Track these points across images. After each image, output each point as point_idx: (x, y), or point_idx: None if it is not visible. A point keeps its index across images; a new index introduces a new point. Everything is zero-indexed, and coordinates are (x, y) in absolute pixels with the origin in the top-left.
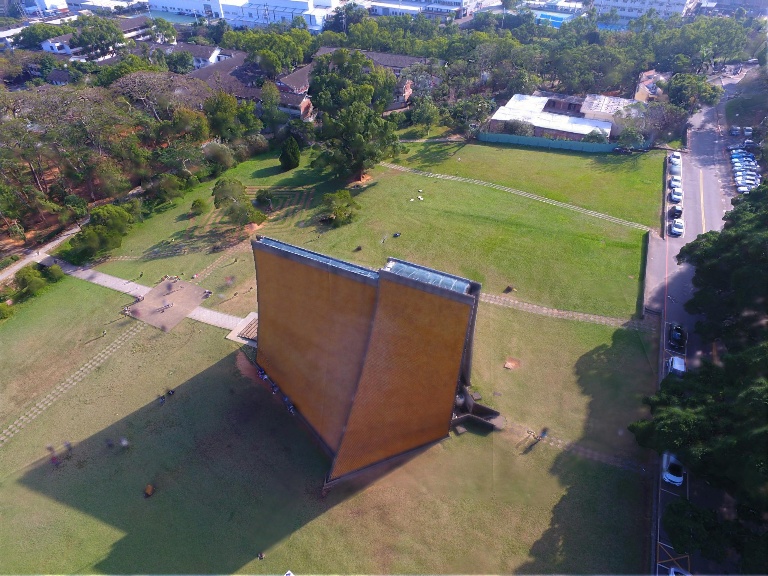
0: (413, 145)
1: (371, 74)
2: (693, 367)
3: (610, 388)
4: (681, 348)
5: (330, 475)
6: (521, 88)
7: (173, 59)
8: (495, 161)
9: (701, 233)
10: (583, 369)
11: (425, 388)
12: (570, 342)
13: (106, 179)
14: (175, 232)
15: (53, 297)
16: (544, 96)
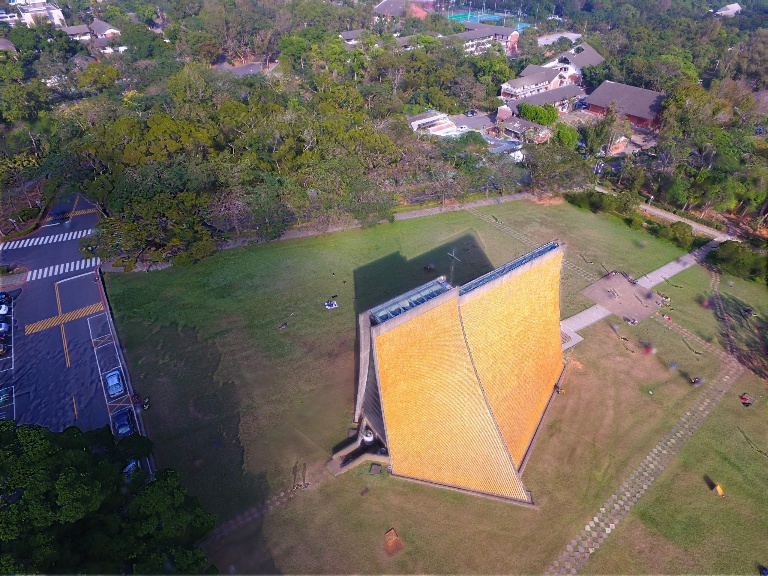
0: None
1: None
2: None
3: None
4: None
5: None
6: None
7: None
8: None
9: None
10: None
11: None
12: None
13: None
14: None
15: (652, 244)
16: None
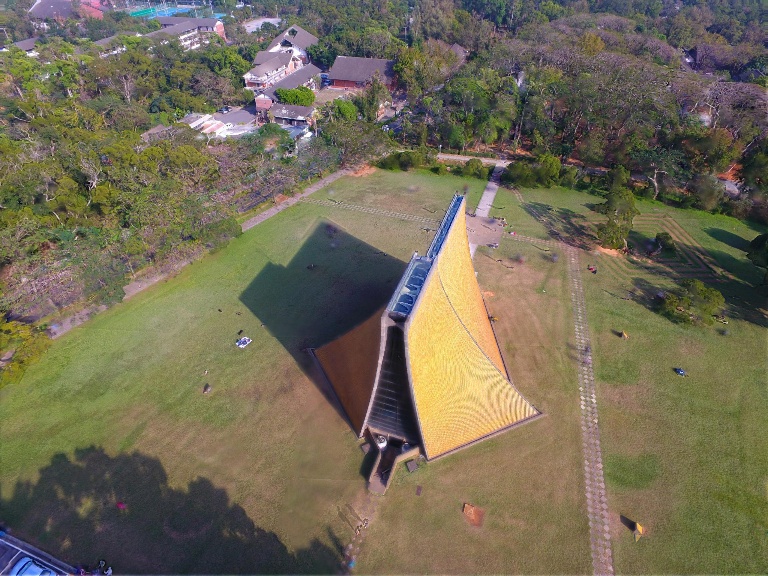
0: None
1: None
2: None
3: None
4: None
5: (316, 349)
6: None
7: None
8: None
9: None
10: None
11: None
12: None
13: (584, 143)
14: (568, 208)
15: (463, 183)
16: None
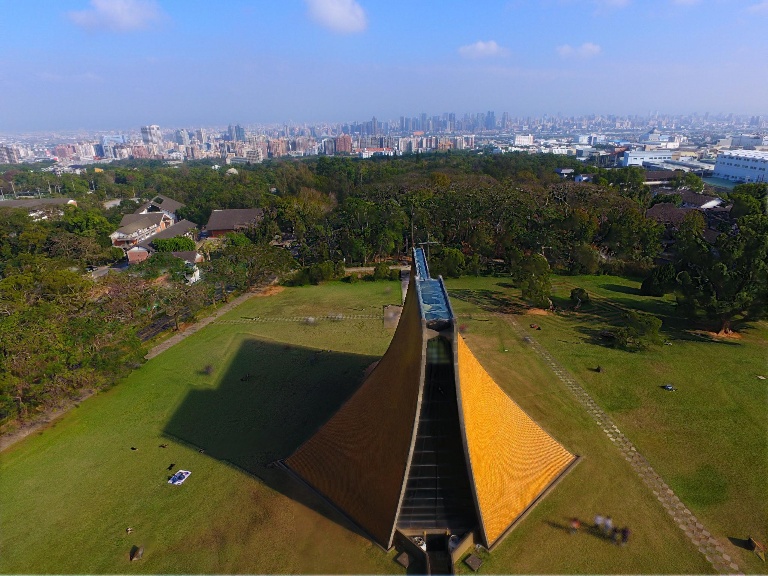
0: None
1: None
2: None
3: None
4: None
5: (287, 458)
6: None
7: (659, 199)
8: None
9: None
10: None
11: (384, 445)
12: None
13: (476, 236)
14: (483, 289)
15: (378, 285)
16: None
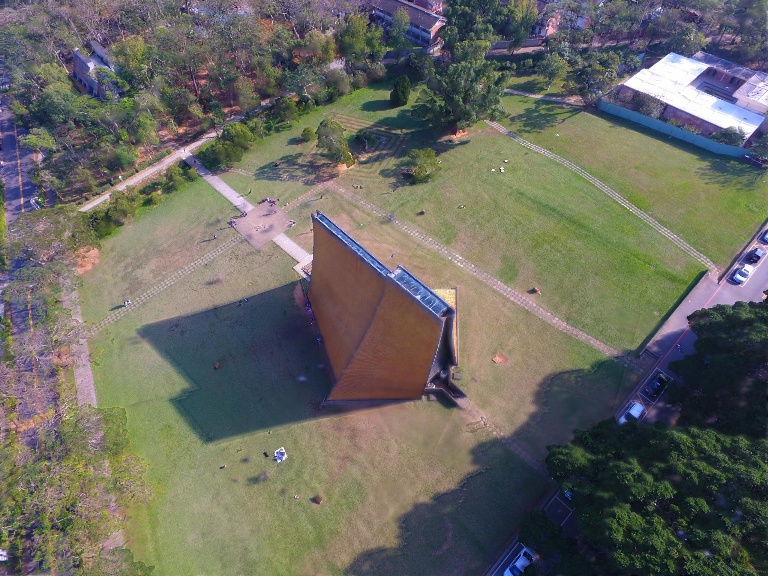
0: (526, 101)
1: (509, 8)
2: (651, 416)
3: (568, 408)
4: (653, 396)
5: (328, 397)
6: (681, 47)
7: None
8: (600, 141)
9: (767, 287)
10: (555, 384)
11: (406, 364)
12: (559, 357)
13: (240, 96)
14: (284, 155)
15: (188, 195)
16: (706, 61)
